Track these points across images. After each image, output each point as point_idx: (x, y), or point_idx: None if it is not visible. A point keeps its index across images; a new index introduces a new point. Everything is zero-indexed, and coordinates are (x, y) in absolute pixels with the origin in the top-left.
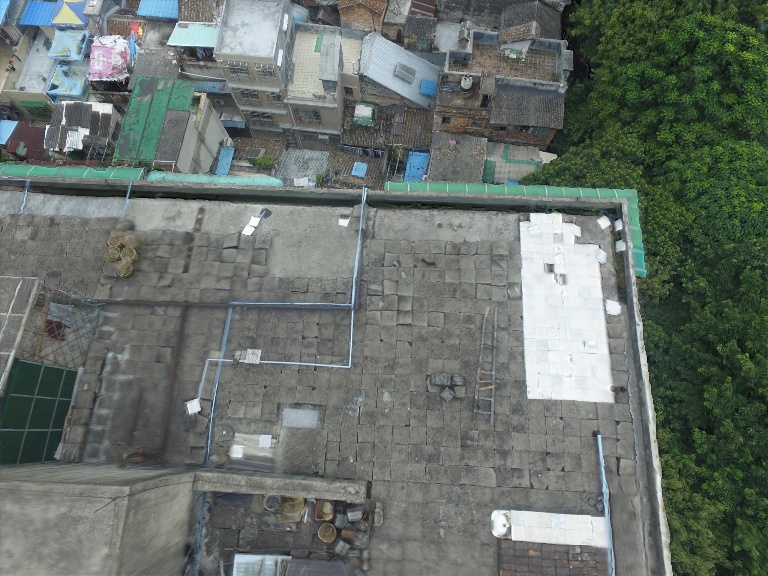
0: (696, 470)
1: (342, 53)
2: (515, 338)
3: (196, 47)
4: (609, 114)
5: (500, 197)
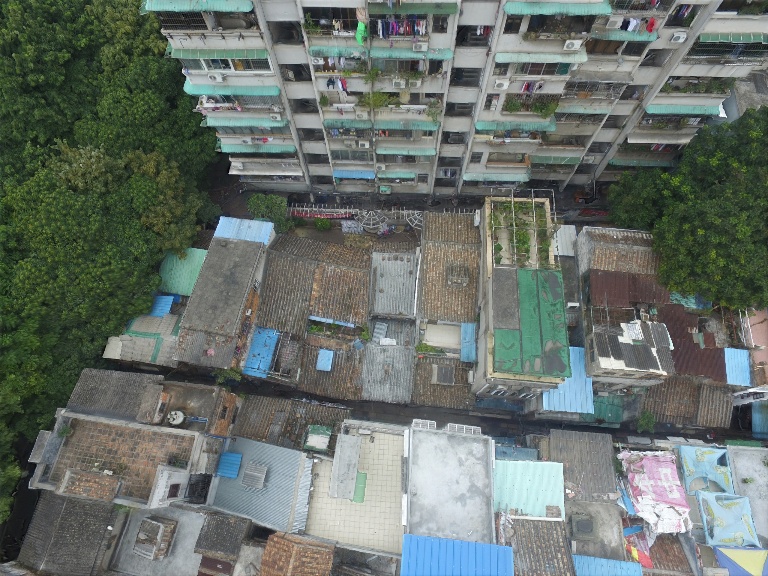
0: None
1: None
2: None
3: None
4: None
5: None
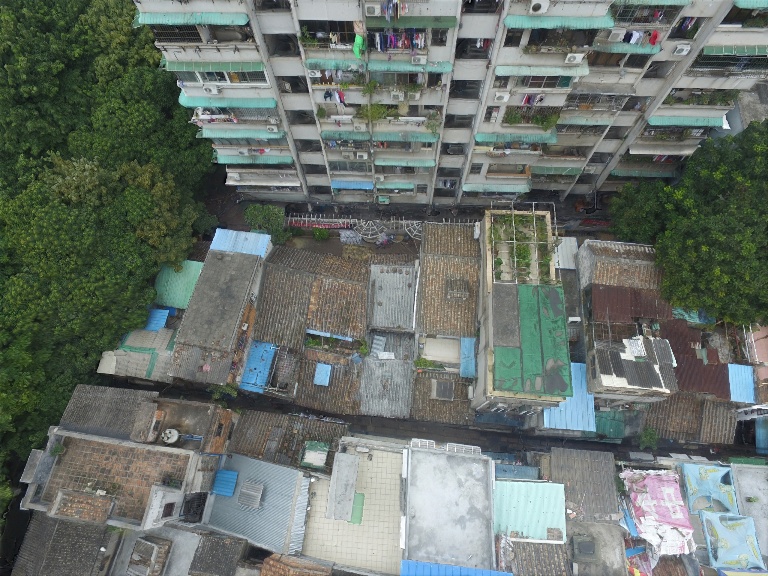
0: None
1: None
2: None
3: None
4: None
5: None
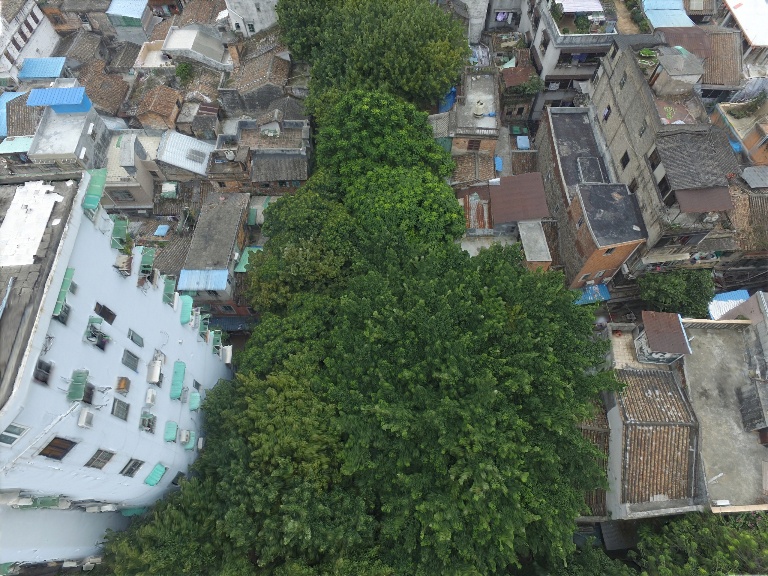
0: (322, 385)
1: (142, 146)
2: None
3: (17, 153)
4: (320, 163)
5: (13, 177)
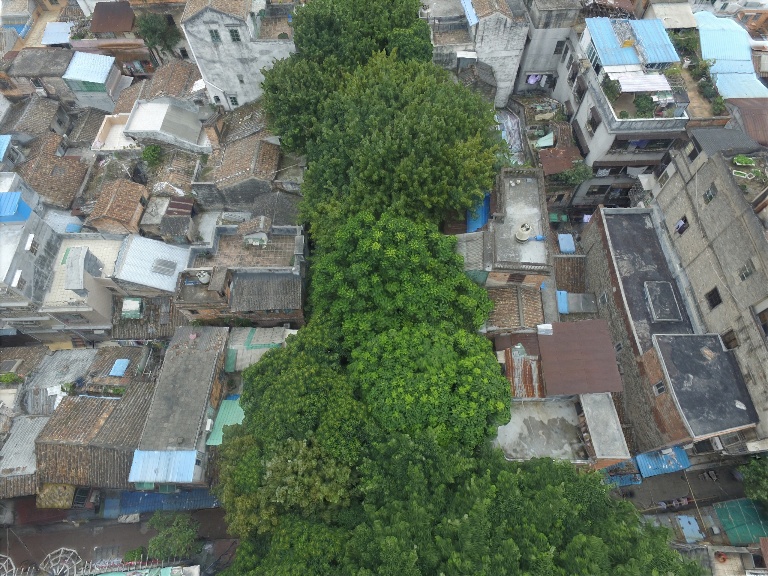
0: None
1: (97, 259)
2: None
3: None
4: None
5: None
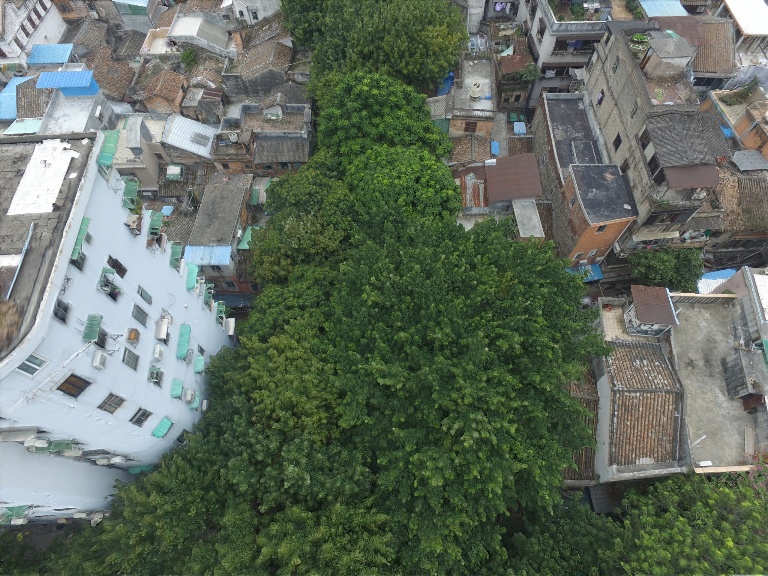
0: (321, 347)
1: (148, 129)
2: (11, 192)
3: None
4: (321, 144)
5: (32, 136)
